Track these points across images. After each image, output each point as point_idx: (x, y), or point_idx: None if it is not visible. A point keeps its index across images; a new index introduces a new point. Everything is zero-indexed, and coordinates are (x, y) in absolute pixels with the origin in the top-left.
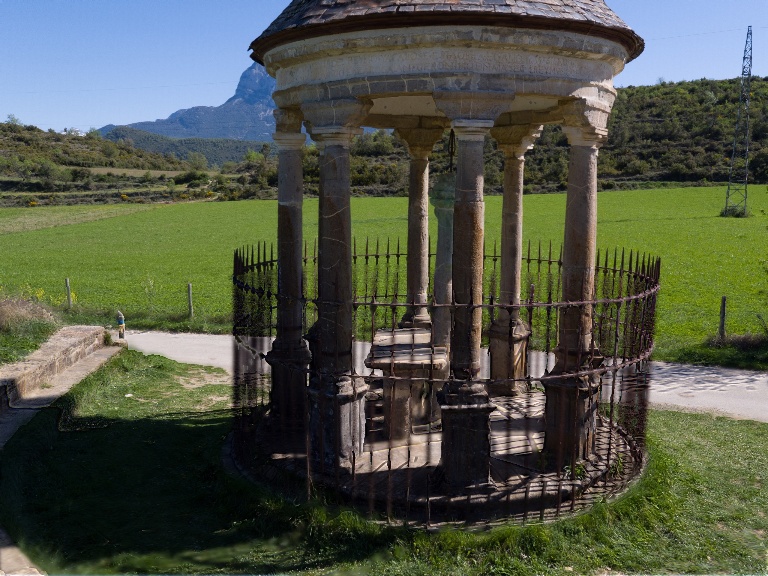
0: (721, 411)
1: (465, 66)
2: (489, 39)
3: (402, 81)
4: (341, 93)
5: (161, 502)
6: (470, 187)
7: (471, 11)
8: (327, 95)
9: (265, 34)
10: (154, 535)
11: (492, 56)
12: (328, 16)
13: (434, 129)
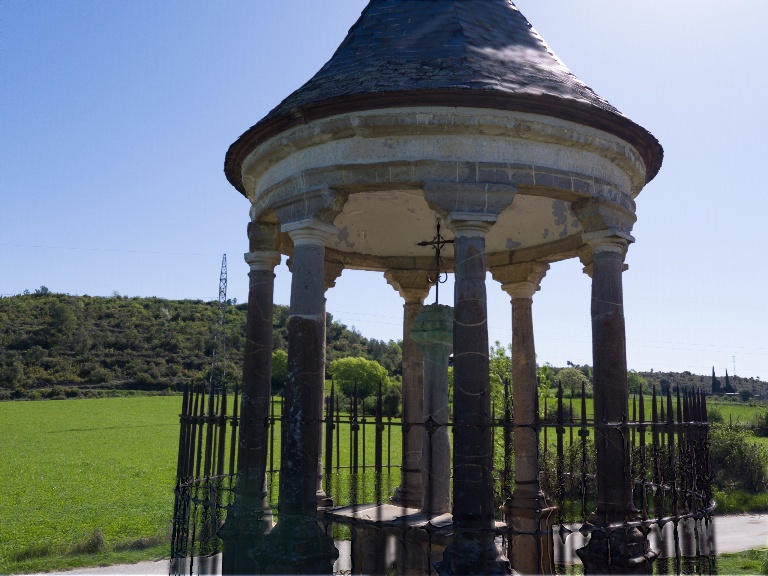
0: (561, 561)
1: (610, 179)
2: (631, 159)
3: (569, 178)
4: (496, 177)
5: None
6: (620, 300)
7: (638, 127)
8: (474, 177)
9: (387, 87)
10: None
11: (621, 176)
12: (512, 88)
13: (336, 263)
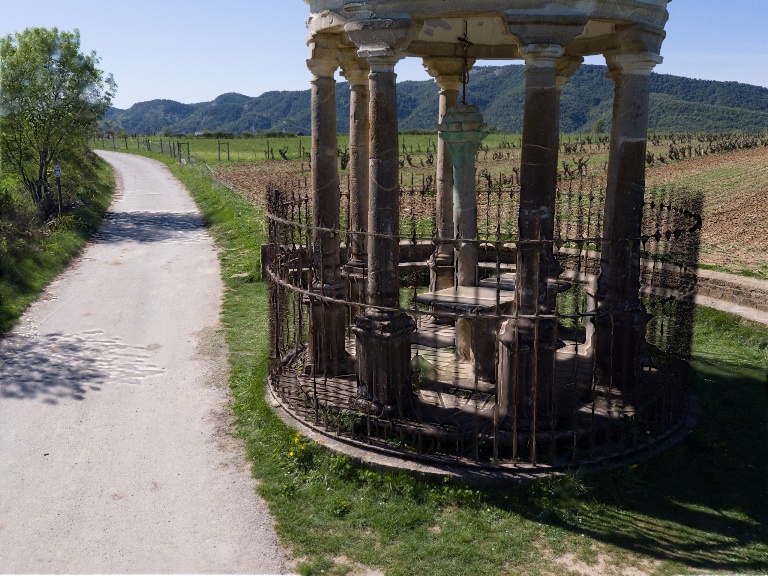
0: (203, 330)
1: None
2: None
3: None
4: None
5: (762, 410)
6: None
7: None
8: None
9: None
10: (763, 392)
11: None
12: None
13: None
